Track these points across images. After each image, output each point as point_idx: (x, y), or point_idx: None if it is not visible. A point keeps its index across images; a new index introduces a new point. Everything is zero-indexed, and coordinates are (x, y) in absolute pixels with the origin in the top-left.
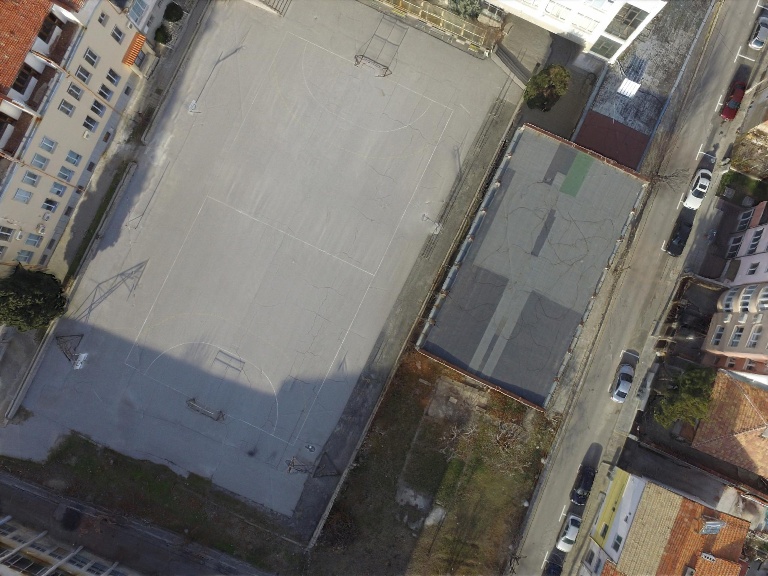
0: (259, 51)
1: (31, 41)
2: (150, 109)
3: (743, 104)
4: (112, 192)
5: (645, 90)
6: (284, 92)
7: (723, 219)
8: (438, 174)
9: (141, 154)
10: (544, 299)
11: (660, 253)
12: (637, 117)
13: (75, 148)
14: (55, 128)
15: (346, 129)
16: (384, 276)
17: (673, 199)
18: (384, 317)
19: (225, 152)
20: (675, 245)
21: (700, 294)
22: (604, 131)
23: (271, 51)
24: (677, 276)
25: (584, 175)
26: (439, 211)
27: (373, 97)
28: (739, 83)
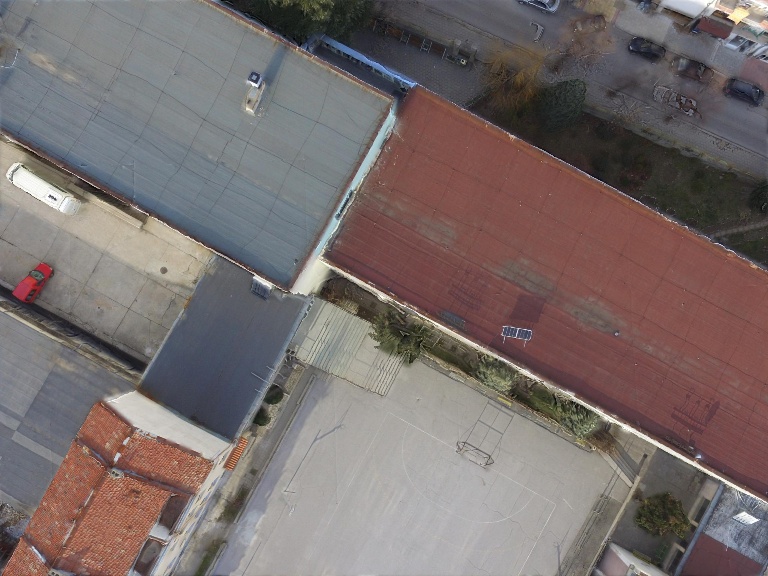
0: (358, 431)
1: (148, 530)
2: (244, 490)
3: None
4: (201, 575)
5: (761, 516)
6: (382, 476)
7: None
8: (536, 571)
9: (232, 533)
10: None
11: None
12: (751, 544)
13: (172, 559)
14: (159, 572)
15: (444, 518)
16: None
17: None
18: None
19: (318, 535)
20: None
21: None
22: (716, 557)
23: (370, 432)
24: None
25: None
26: None
27: (473, 486)
28: None
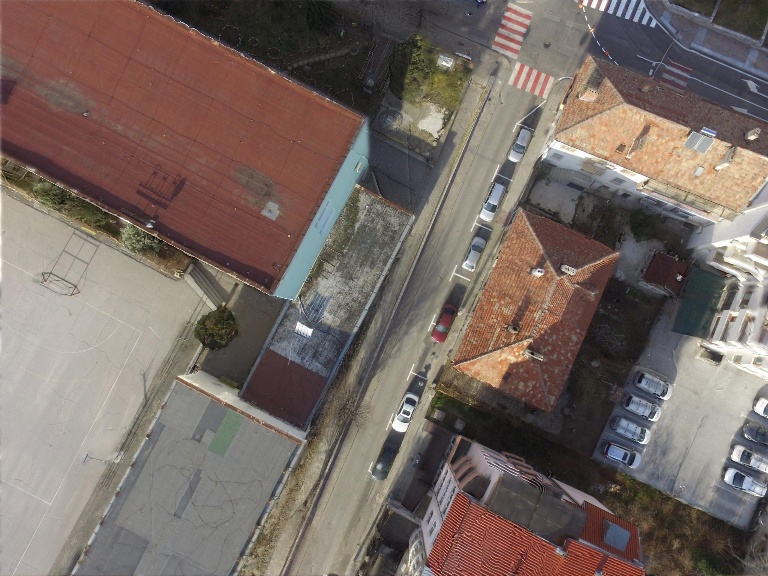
0: None
1: None
2: None
3: (456, 325)
4: None
5: (325, 329)
6: None
7: (431, 443)
8: (122, 399)
9: None
10: (185, 563)
11: (367, 475)
12: (315, 358)
13: None
14: None
15: (29, 349)
16: (60, 505)
17: (382, 419)
18: (58, 548)
19: None
20: (378, 470)
21: (405, 520)
22: (280, 371)
23: None
24: (382, 500)
25: (234, 434)
26: (121, 438)
27: (59, 316)
28: (448, 306)
